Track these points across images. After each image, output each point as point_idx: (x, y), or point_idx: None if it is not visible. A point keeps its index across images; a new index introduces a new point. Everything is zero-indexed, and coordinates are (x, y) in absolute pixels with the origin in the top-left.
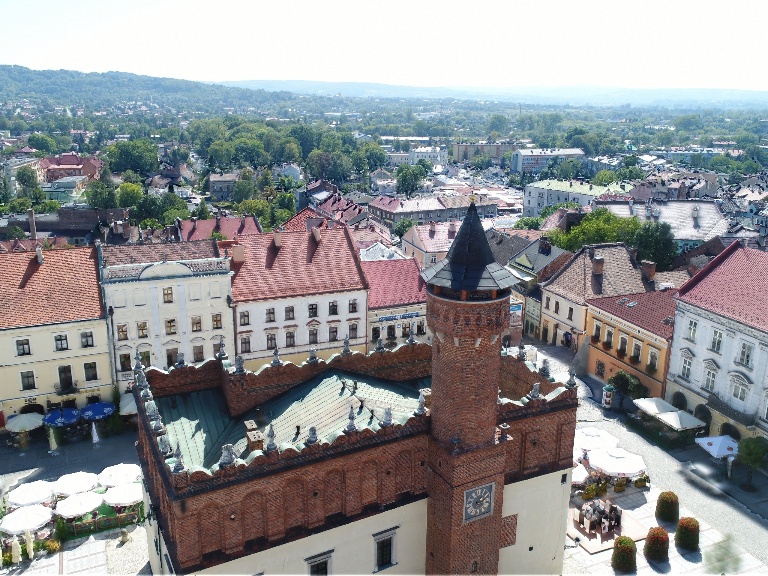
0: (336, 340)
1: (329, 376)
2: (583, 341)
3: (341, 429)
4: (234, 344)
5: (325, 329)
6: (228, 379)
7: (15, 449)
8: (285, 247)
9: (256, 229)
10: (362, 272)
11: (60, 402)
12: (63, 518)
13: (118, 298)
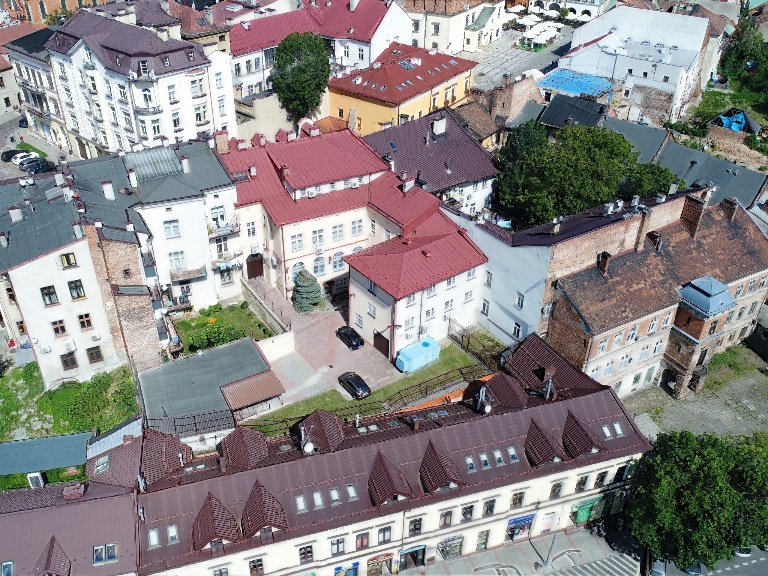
0: None
1: None
2: None
3: None
4: None
5: None
6: None
7: None
8: None
9: None
10: None
11: None
12: None
13: None
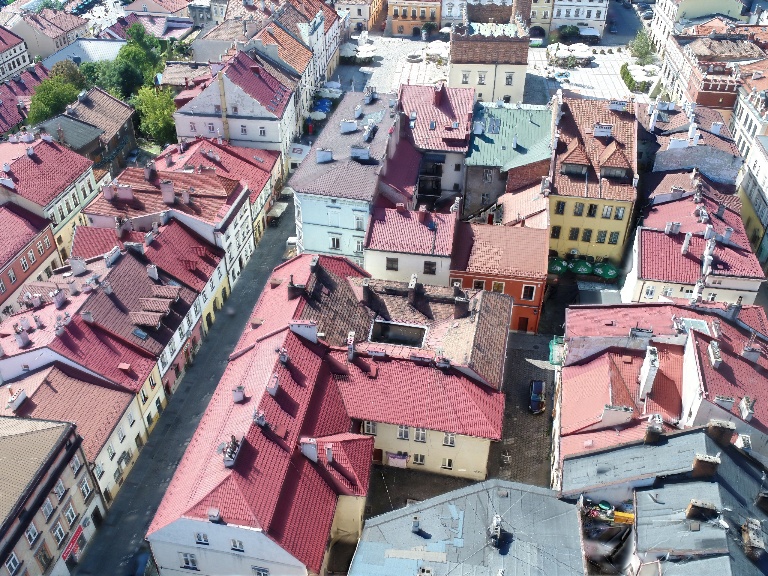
0: None
1: (471, 23)
2: (388, 20)
3: None
4: None
5: None
6: None
7: None
8: (303, 3)
9: (8, 33)
10: (331, 8)
11: None
12: None
13: None
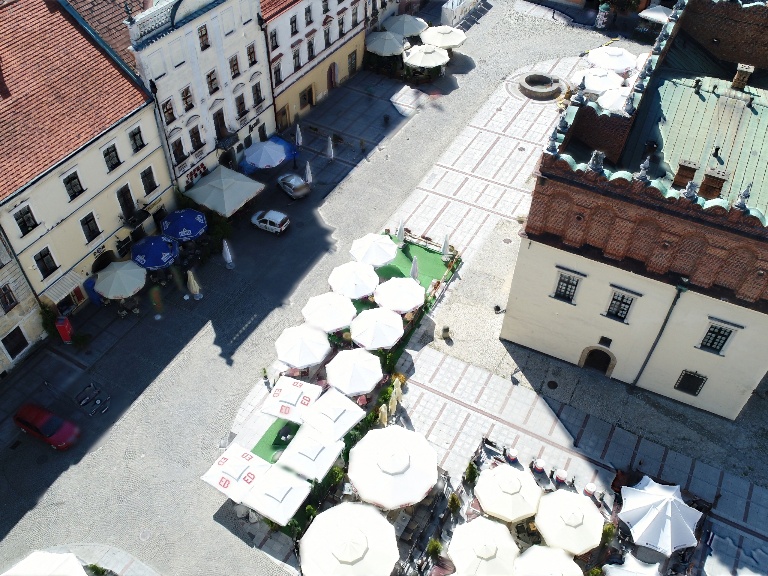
0: (344, 34)
1: (660, 83)
2: None
3: (759, 134)
4: (269, 78)
5: (335, 24)
6: (622, 125)
7: (138, 316)
8: None
9: None
10: None
11: (128, 236)
12: (386, 350)
13: (155, 64)
